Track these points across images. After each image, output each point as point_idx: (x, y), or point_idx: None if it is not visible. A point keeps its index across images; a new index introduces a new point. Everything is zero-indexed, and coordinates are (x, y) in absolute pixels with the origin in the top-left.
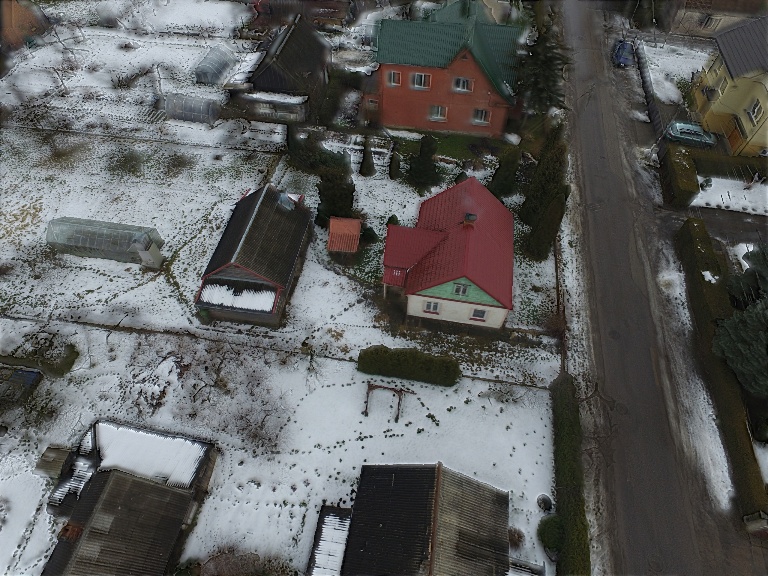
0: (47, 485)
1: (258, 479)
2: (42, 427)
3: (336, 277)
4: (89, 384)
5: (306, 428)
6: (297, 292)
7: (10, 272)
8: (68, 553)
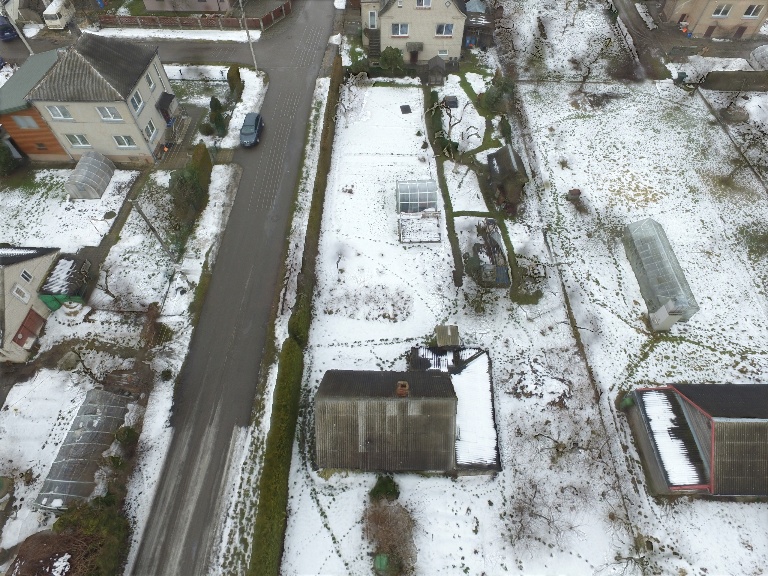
0: (430, 336)
1: (482, 528)
2: (470, 309)
3: (767, 560)
4: (515, 326)
5: (549, 572)
6: (713, 506)
7: (584, 214)
8: (390, 391)
